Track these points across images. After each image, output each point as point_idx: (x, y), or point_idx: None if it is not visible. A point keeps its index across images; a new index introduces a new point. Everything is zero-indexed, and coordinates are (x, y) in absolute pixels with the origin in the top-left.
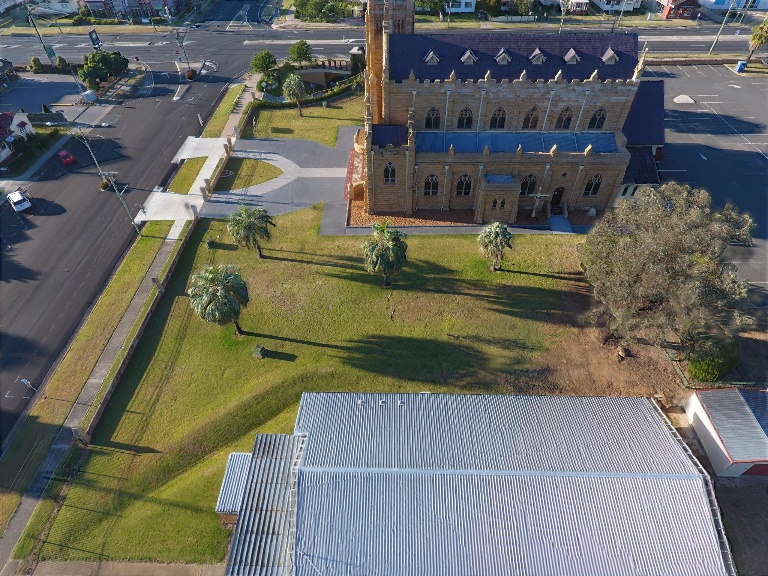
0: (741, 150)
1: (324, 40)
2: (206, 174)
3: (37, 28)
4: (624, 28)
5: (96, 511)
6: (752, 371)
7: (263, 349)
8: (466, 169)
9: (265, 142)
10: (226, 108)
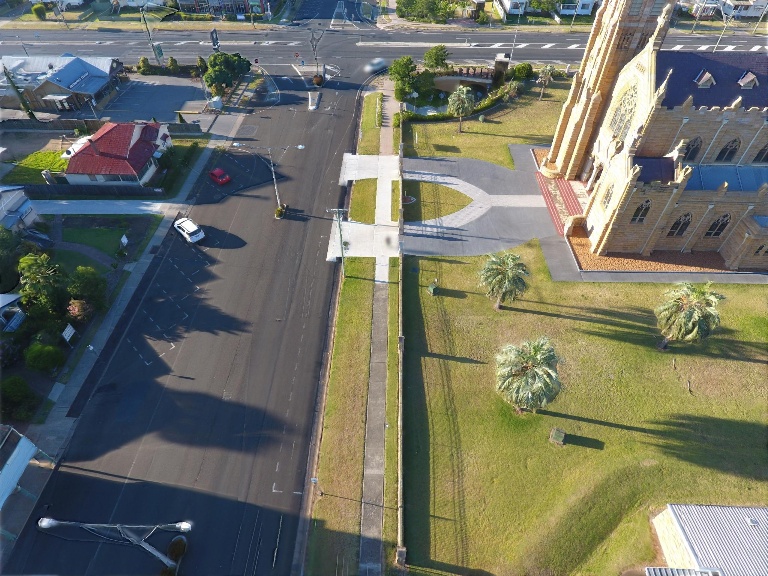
0: None
1: (444, 43)
2: (385, 200)
3: (147, 25)
4: (762, 36)
5: None
6: None
7: (564, 433)
8: (731, 209)
9: (434, 162)
10: (372, 120)
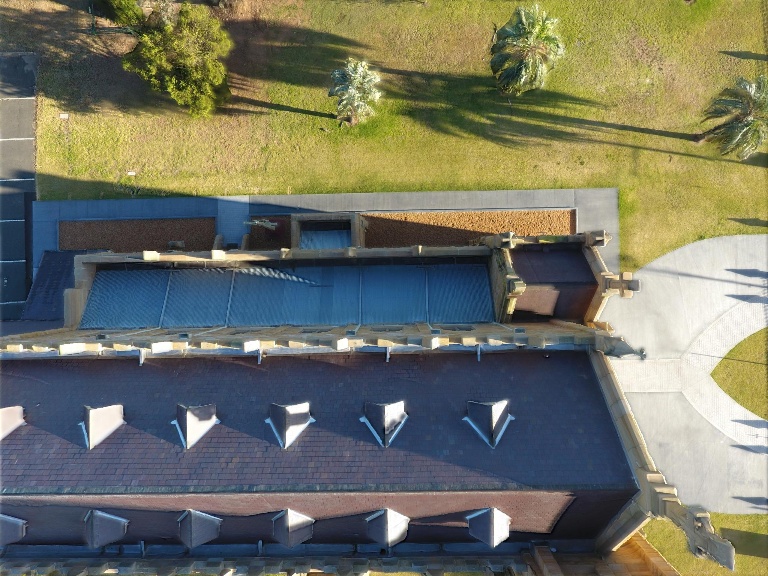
0: None
1: None
2: None
3: None
4: None
5: None
6: None
7: None
8: None
9: None
10: None
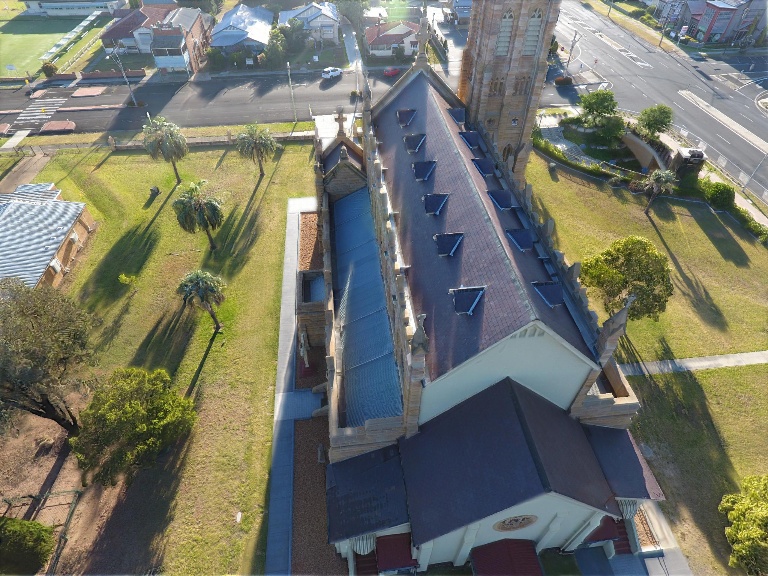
0: None
1: (759, 139)
2: None
3: None
4: None
5: (68, 163)
6: None
7: (154, 191)
8: None
9: None
10: None
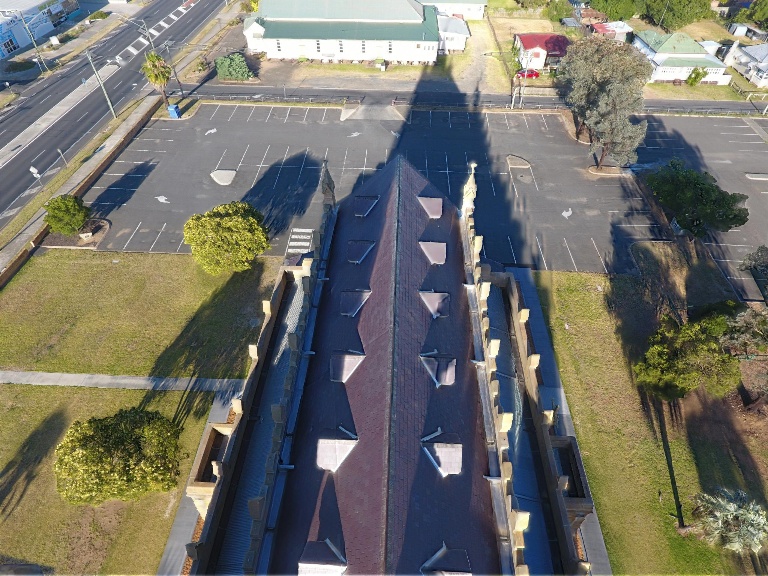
0: (357, 179)
1: None
2: None
3: None
4: None
5: None
6: None
7: None
8: None
9: None
10: None
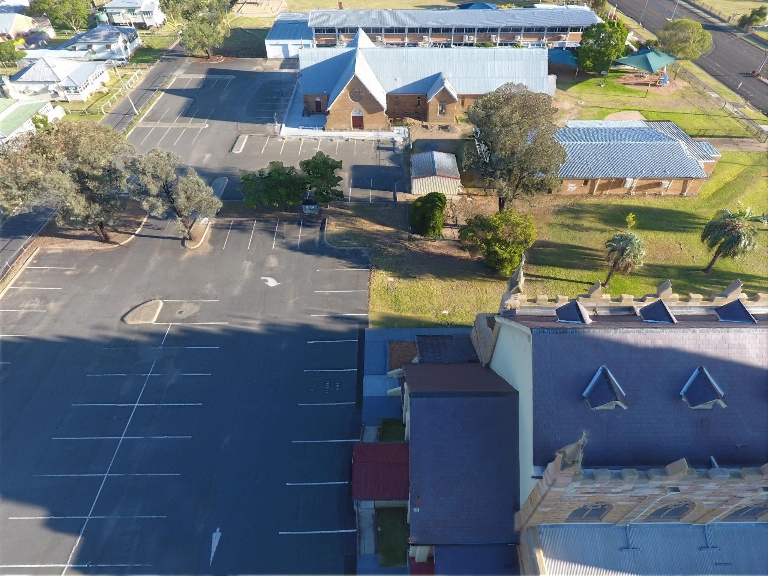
0: None
1: None
2: None
3: None
4: None
5: (767, 161)
6: (400, 209)
7: None
8: None
9: None
10: None
